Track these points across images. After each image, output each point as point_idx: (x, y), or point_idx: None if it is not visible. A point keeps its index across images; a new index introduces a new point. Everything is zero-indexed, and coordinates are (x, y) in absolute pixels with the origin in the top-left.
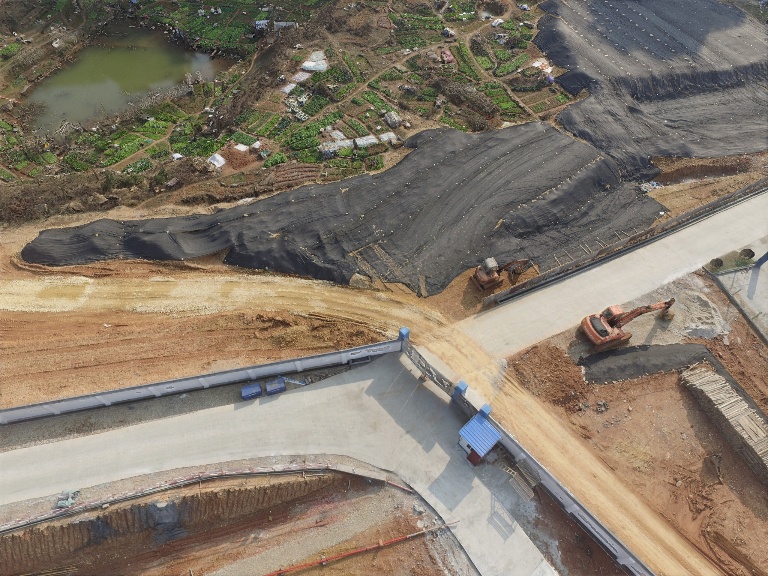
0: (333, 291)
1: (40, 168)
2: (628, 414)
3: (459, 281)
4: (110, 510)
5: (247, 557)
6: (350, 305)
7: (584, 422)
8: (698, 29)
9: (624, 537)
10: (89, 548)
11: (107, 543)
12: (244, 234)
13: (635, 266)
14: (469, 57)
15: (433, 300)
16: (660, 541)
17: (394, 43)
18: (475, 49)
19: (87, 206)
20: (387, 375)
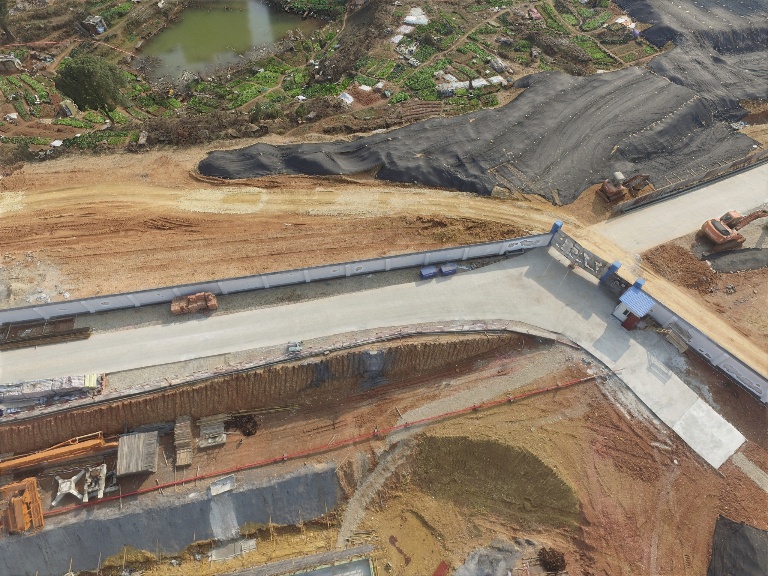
0: (477, 201)
1: (170, 111)
2: (754, 296)
3: (587, 194)
4: (331, 356)
5: (443, 398)
6: (495, 211)
7: (717, 301)
8: None
9: None
10: (310, 390)
11: (324, 386)
12: (392, 154)
13: (738, 188)
14: (555, 15)
15: (567, 208)
16: None
17: (483, 2)
18: (559, 8)
19: (241, 133)
20: (540, 263)
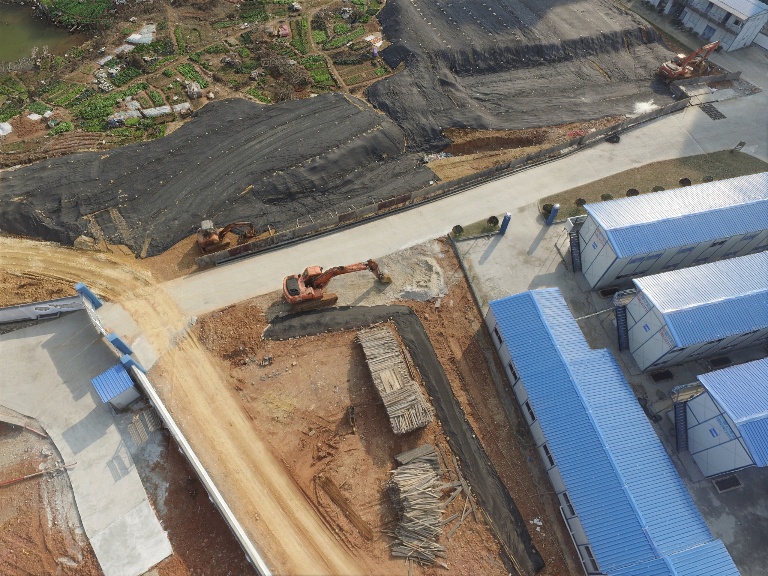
0: (57, 252)
1: None
2: (290, 368)
3: (184, 244)
4: None
5: None
6: (67, 265)
7: (243, 375)
8: (542, 4)
9: (234, 481)
10: None
11: None
12: None
13: (378, 232)
14: (306, 31)
15: (150, 261)
16: (269, 485)
17: (236, 17)
18: (315, 23)
19: None
20: (70, 330)
